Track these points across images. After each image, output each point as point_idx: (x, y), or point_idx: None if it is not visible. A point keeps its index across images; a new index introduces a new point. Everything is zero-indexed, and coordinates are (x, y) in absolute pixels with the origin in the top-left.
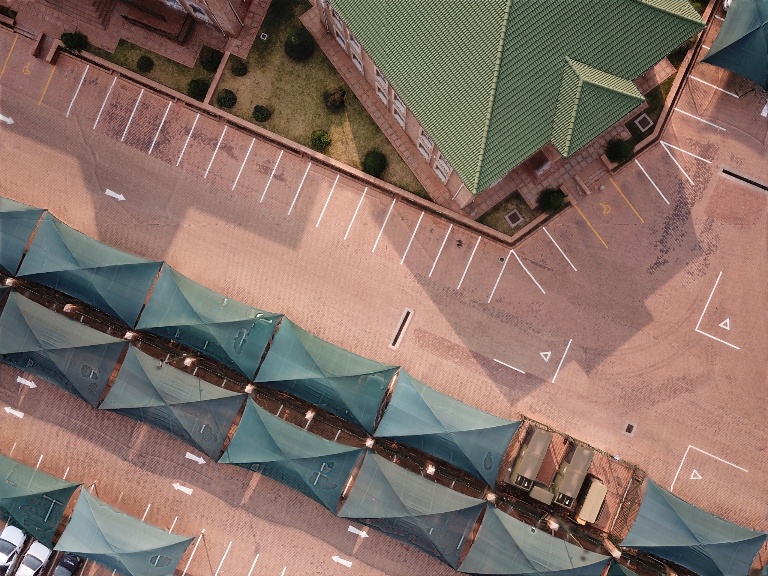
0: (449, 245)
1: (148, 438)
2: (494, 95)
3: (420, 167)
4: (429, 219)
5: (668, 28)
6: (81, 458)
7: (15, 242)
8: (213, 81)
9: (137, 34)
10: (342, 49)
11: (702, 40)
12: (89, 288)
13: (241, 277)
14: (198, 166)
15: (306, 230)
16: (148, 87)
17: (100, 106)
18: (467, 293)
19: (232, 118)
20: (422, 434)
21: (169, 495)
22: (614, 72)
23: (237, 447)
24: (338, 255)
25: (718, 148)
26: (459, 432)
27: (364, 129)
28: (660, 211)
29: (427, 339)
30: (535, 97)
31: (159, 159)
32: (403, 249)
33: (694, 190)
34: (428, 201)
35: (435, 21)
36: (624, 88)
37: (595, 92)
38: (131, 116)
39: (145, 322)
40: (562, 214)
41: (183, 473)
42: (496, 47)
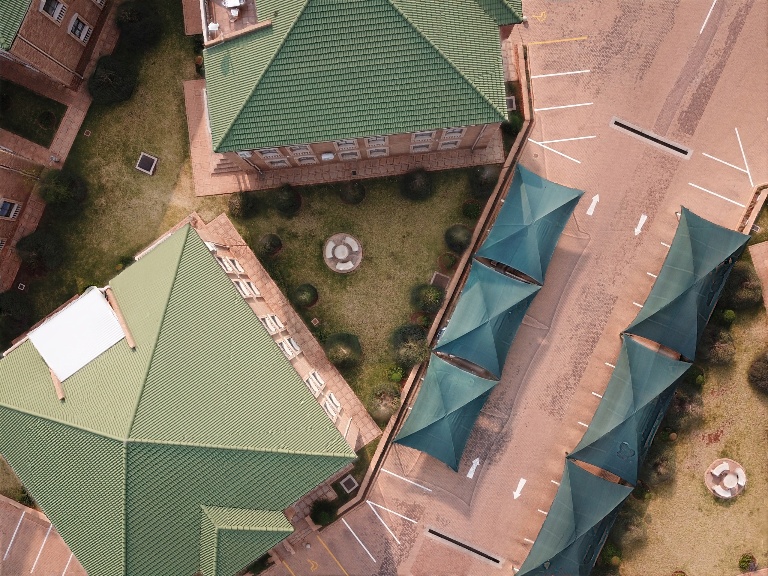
0: None
1: None
2: (125, 547)
3: None
4: None
5: (313, 465)
6: None
7: None
8: None
9: None
10: None
11: (408, 403)
12: None
13: None
14: None
15: (21, 575)
16: None
17: None
18: None
19: None
20: None
21: None
22: (260, 508)
23: None
24: None
25: (424, 508)
26: None
27: None
28: (367, 569)
29: None
30: (174, 540)
31: None
32: None
33: (400, 549)
34: None
35: (68, 471)
36: (270, 523)
37: (235, 534)
38: None
39: None
40: (270, 569)
41: None
42: (120, 509)
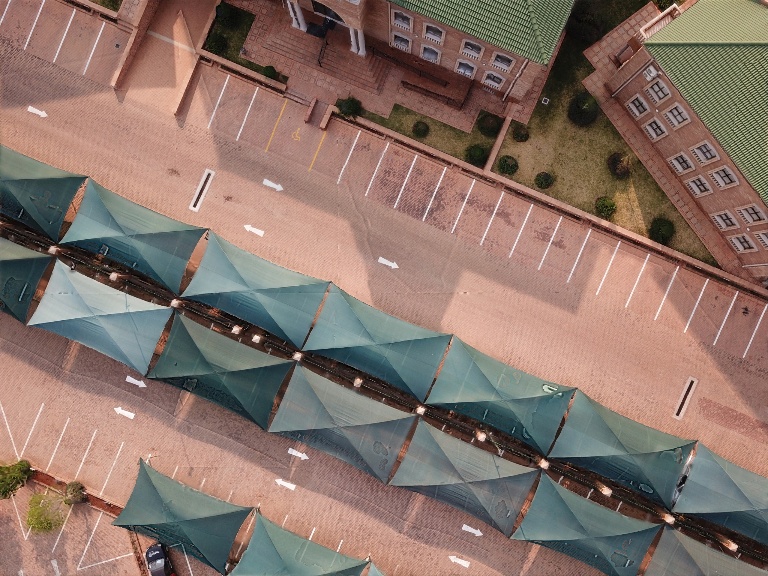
0: (735, 313)
1: (423, 510)
2: None
3: (708, 234)
4: (714, 286)
5: None
6: (355, 531)
7: (303, 316)
8: (495, 147)
9: (412, 99)
10: (627, 113)
11: None
12: (383, 364)
13: (519, 346)
14: (474, 233)
15: (586, 298)
16: (423, 153)
17: (372, 172)
18: (753, 361)
19: (515, 185)
20: (729, 511)
21: (446, 568)
22: None
23: (532, 523)
24: (619, 323)
25: None
26: (767, 509)
27: (650, 195)
28: None
29: (712, 409)
30: None
31: (433, 226)
32: (687, 317)
33: None
34: (718, 269)
35: None
36: None
37: None
38: (404, 182)
39: (439, 397)
40: None
41: (460, 545)
42: None
